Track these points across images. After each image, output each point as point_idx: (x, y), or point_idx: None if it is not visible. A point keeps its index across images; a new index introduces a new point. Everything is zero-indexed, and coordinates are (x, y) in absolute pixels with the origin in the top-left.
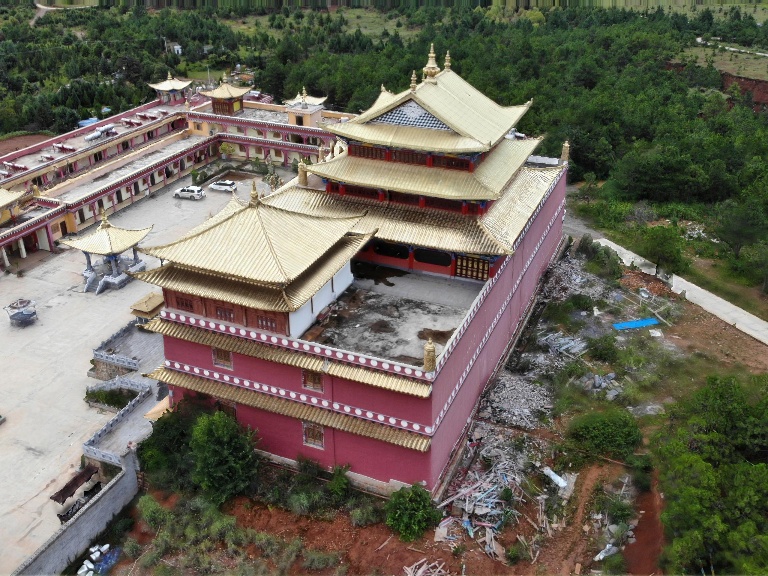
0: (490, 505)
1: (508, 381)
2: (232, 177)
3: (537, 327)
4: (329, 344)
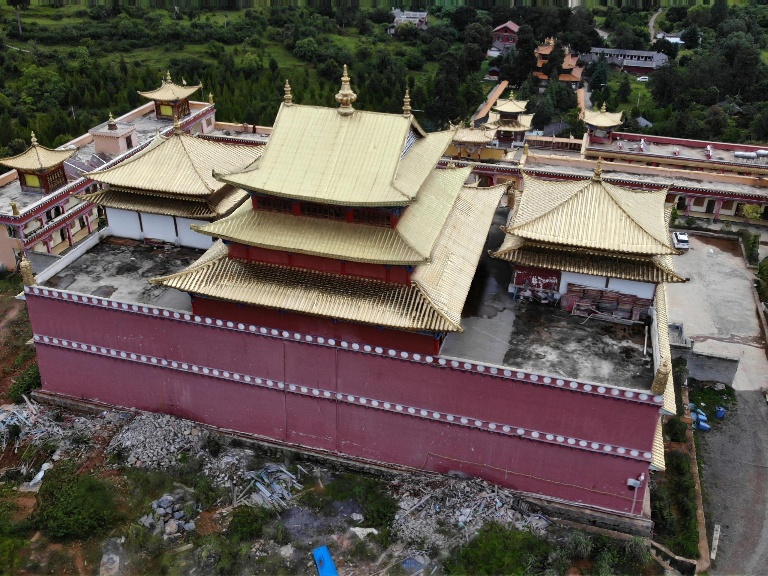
0: (7, 421)
1: (169, 422)
2: (726, 244)
3: (318, 467)
4: (107, 249)
